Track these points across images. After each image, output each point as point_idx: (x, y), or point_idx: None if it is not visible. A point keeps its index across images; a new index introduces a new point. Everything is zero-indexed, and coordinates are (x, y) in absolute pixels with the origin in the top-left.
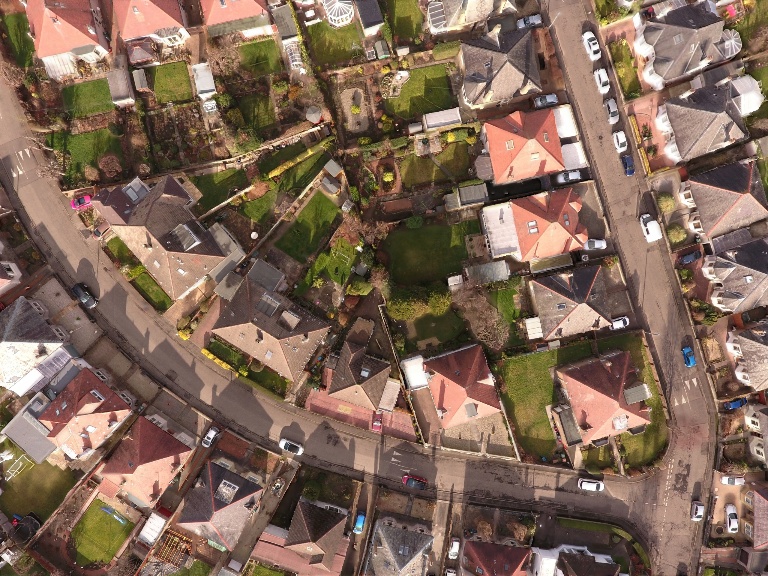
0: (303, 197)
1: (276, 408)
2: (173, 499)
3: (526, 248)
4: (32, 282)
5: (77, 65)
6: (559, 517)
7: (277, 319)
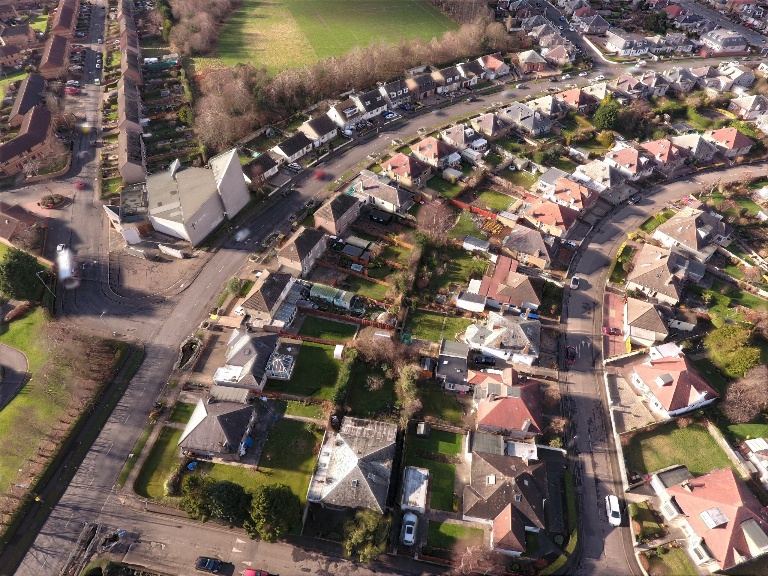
0: (760, 294)
1: (598, 277)
2: None
3: None
4: None
5: (767, 202)
6: None
7: None
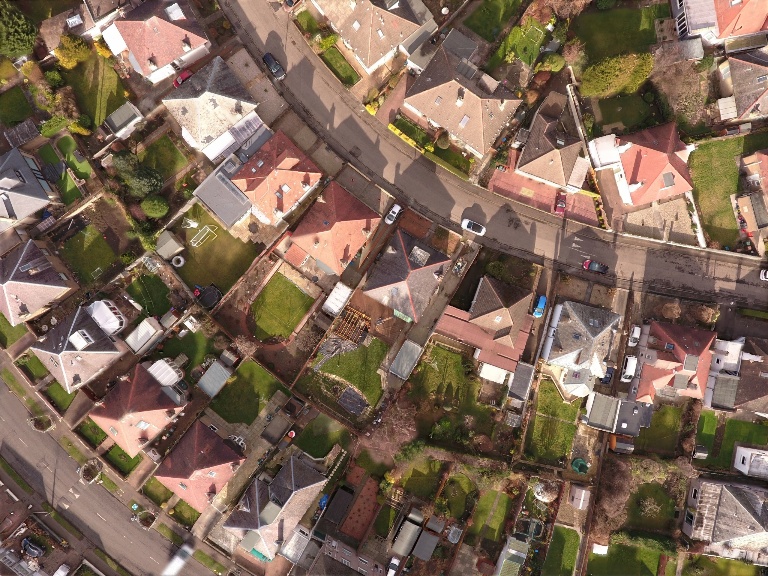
0: None
1: (458, 189)
2: (353, 276)
3: (725, 22)
4: (221, 53)
5: None
6: (740, 308)
7: (476, 83)
